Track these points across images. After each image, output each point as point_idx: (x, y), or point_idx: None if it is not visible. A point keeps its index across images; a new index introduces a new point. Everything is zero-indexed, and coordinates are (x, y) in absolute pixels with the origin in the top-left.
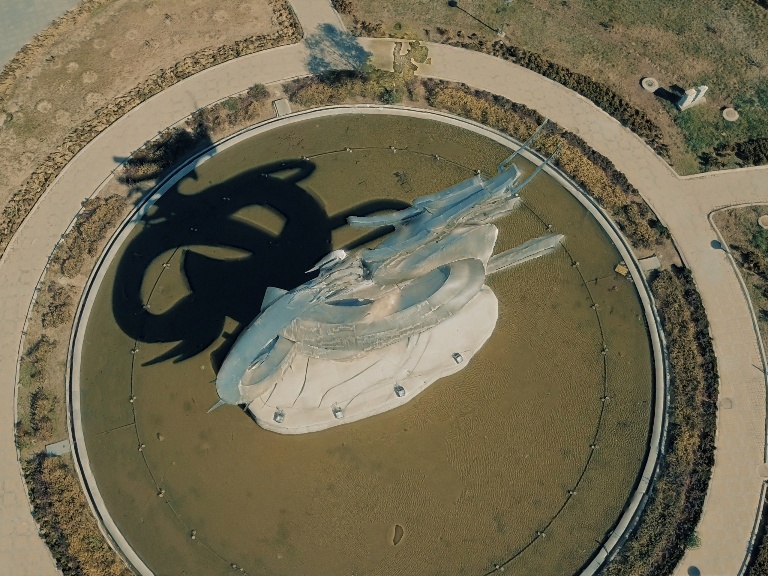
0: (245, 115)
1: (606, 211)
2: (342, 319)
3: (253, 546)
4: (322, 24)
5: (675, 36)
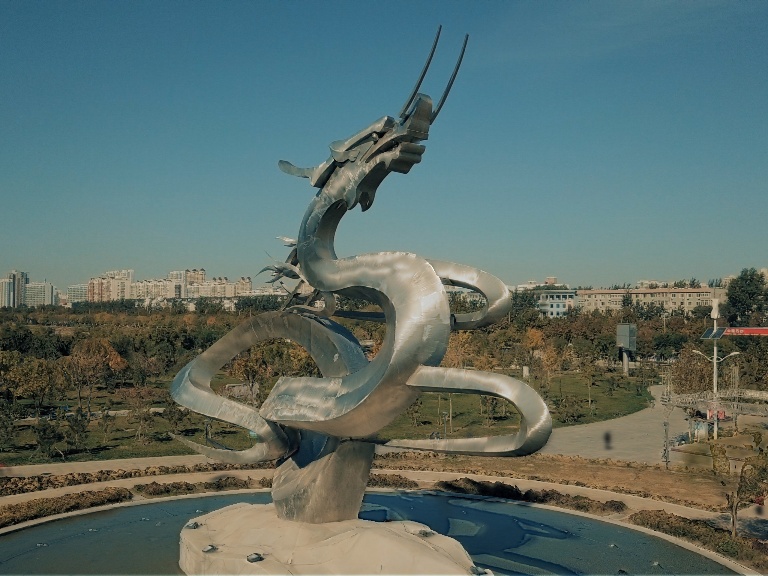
0: None
1: None
2: None
3: (24, 568)
4: (761, 518)
5: None
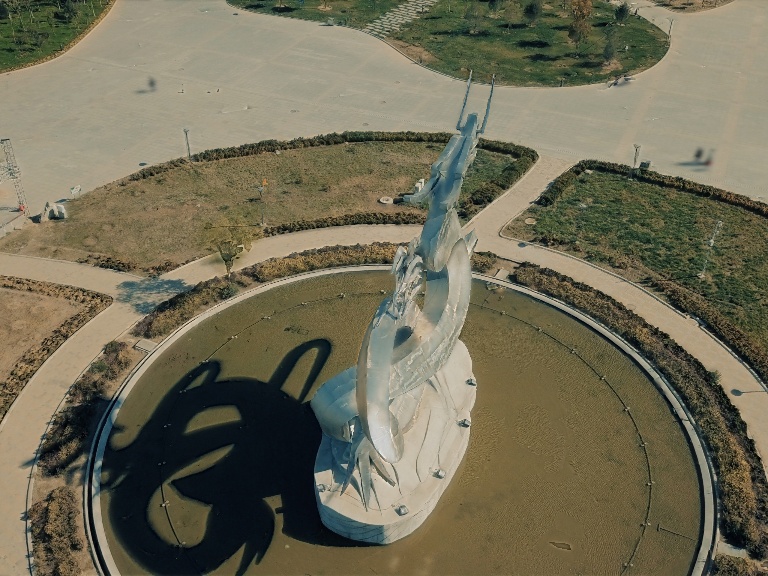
0: (120, 366)
1: None
2: (408, 351)
3: None
4: (120, 285)
5: (370, 175)
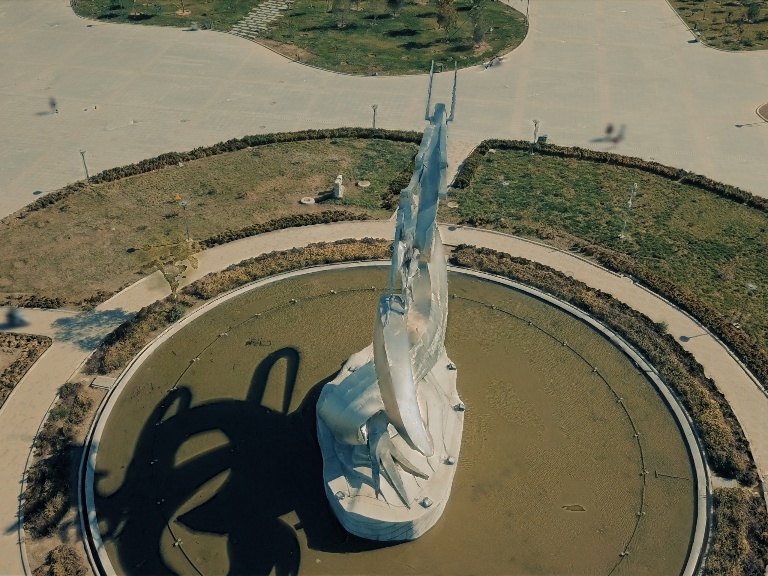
0: (83, 408)
1: (385, 259)
2: (410, 344)
3: None
4: (53, 323)
5: (283, 177)
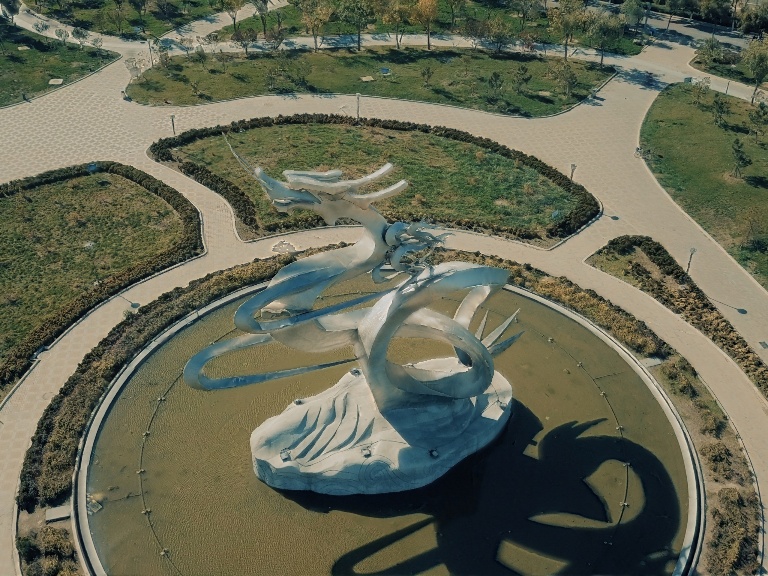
0: None
1: (83, 574)
2: None
3: None
4: None
5: None
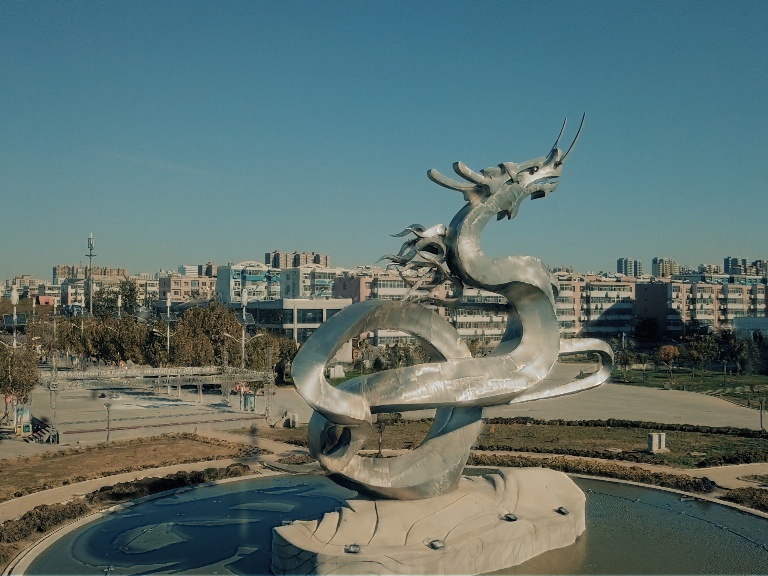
0: (226, 473)
1: None
2: None
3: None
4: None
5: (614, 440)
